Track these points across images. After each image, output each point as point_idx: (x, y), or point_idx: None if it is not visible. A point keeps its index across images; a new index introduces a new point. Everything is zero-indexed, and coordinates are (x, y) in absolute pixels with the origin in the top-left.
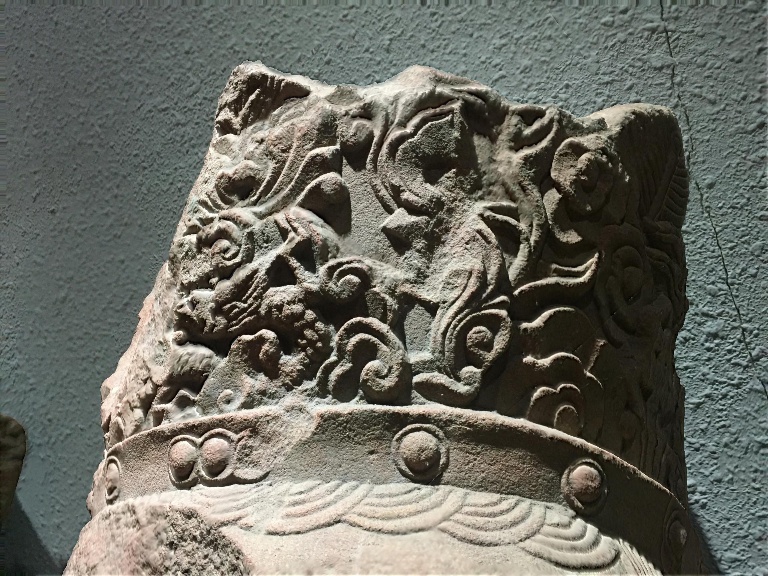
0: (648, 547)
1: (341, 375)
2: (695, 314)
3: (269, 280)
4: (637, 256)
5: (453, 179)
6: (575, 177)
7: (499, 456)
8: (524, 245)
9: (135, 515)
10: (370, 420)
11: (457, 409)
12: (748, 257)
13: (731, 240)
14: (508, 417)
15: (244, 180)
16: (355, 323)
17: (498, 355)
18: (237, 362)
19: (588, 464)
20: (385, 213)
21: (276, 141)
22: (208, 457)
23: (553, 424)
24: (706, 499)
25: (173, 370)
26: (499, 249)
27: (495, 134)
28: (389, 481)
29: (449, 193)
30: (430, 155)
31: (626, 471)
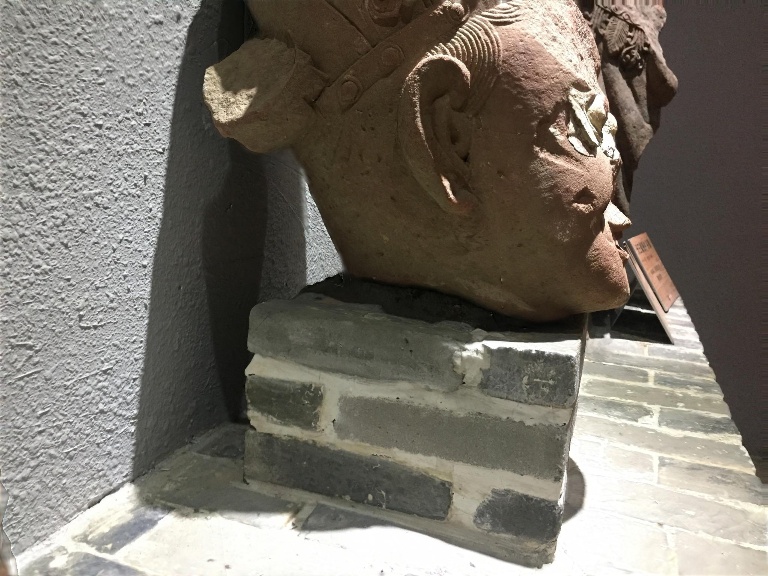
0: None
1: None
2: None
3: None
4: None
5: None
6: None
7: None
8: None
9: (568, 0)
10: None
11: None
12: None
13: None
14: None
15: None
16: None
17: None
18: None
19: None
20: None
21: None
22: None
23: None
24: None
25: None
26: None
27: None
28: None
29: None
30: None
31: None
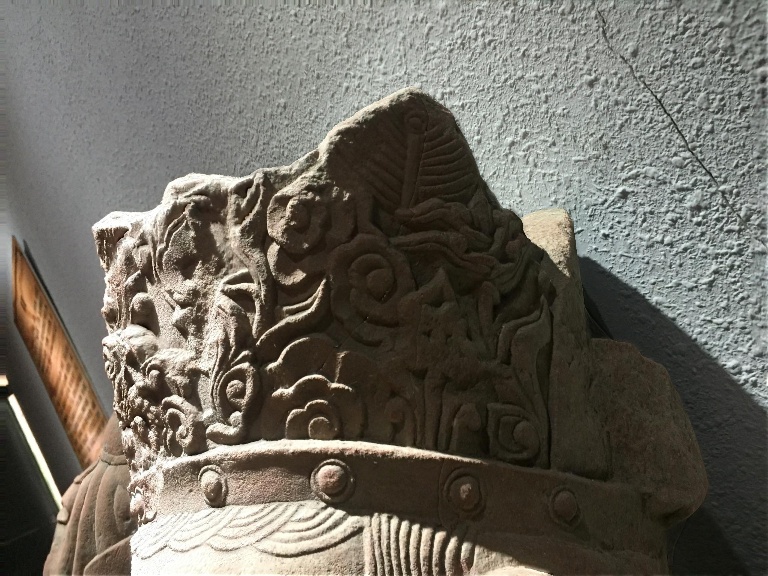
0: (417, 510)
1: (169, 440)
2: (672, 192)
3: (128, 383)
4: (376, 260)
5: (201, 269)
6: (285, 226)
7: (258, 476)
8: (256, 302)
9: None
10: (183, 470)
11: (228, 448)
12: (698, 114)
13: (675, 103)
14: (271, 441)
15: (110, 312)
16: (164, 403)
17: (250, 398)
18: (137, 439)
19: (329, 463)
20: (172, 311)
21: (113, 280)
22: (135, 507)
23: (309, 436)
24: (754, 377)
25: (125, 448)
26: (234, 315)
27: (223, 217)
28: (201, 509)
29: (202, 281)
30: (180, 258)
31: (372, 458)
